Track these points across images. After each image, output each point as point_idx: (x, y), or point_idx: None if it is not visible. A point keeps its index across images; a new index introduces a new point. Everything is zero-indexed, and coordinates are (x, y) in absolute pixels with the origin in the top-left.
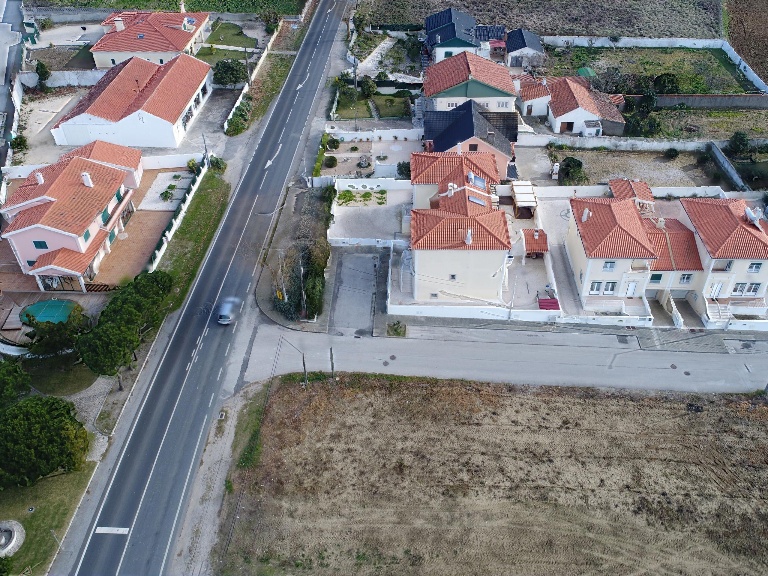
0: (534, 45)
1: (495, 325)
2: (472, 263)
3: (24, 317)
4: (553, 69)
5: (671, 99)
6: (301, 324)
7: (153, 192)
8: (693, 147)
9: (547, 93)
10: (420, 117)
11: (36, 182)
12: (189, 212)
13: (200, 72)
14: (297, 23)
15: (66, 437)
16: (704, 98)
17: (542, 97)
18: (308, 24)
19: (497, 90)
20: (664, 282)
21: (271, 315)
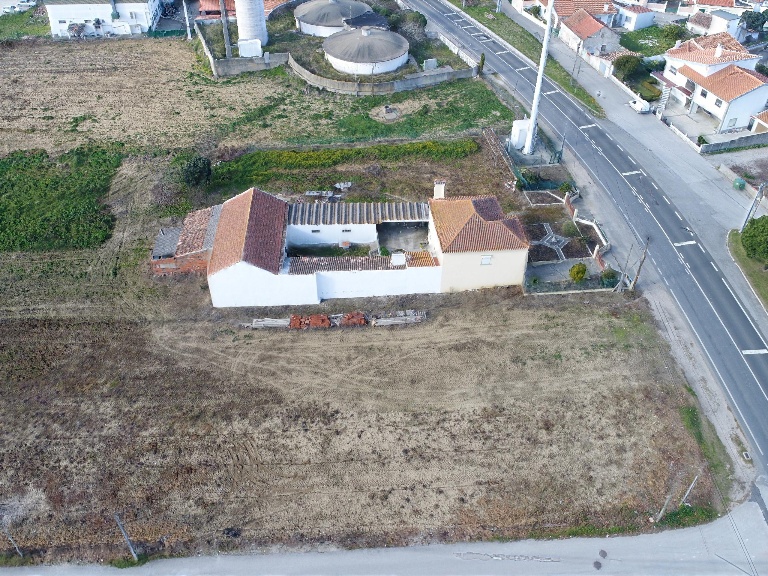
0: None
1: None
2: None
3: None
4: None
5: None
6: None
7: None
8: None
9: None
10: None
11: None
12: None
13: None
14: None
15: None
16: None
17: None
18: None
19: None
20: None
21: None
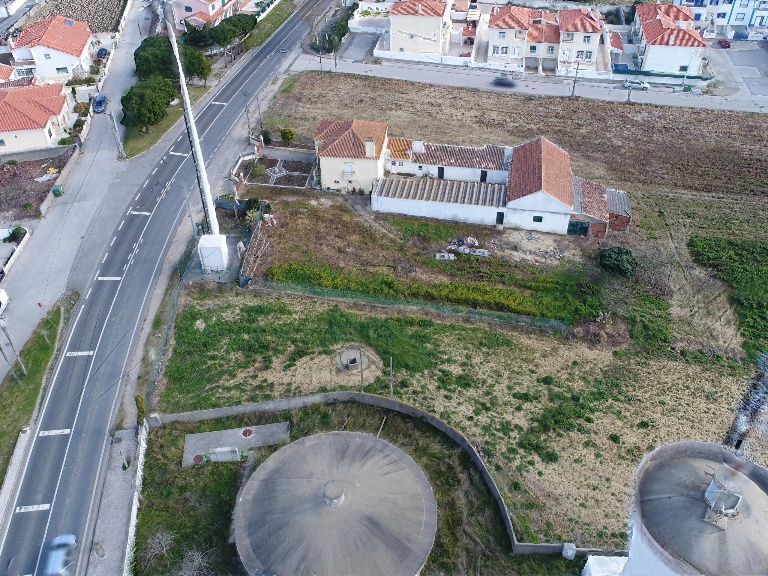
0: None
1: (433, 64)
2: (422, 26)
3: None
4: None
5: None
6: (324, 55)
7: (251, 4)
8: (607, 10)
9: None
10: None
11: None
12: (271, 13)
13: None
14: None
15: (202, 60)
16: None
17: None
18: None
19: None
20: (538, 52)
21: (309, 50)
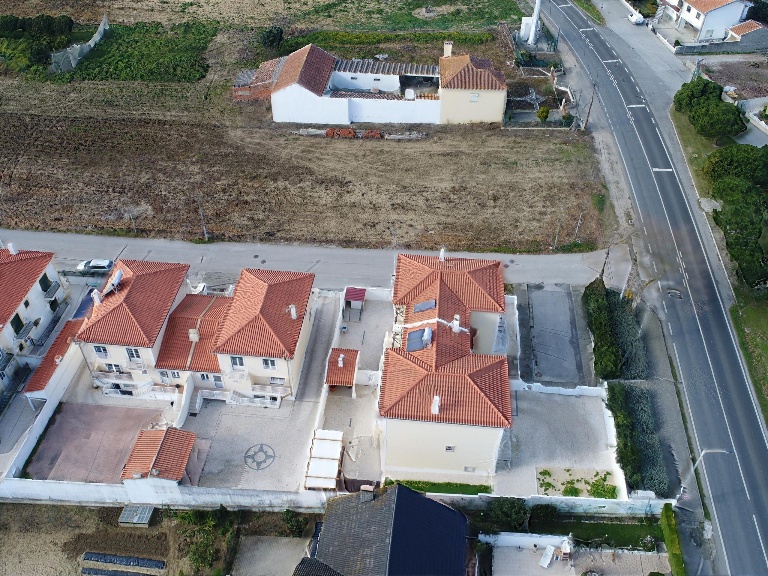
0: None
1: None
2: None
3: None
4: None
5: None
6: None
7: None
8: None
9: None
10: None
11: None
12: None
13: None
14: None
15: None
16: None
17: None
18: None
19: None
20: None
21: None
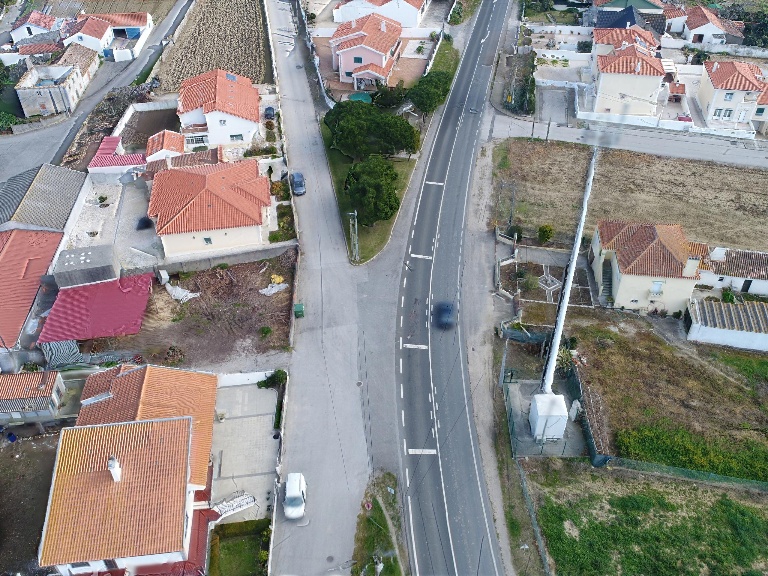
0: None
1: (648, 129)
2: (638, 86)
3: (351, 99)
4: (687, 5)
5: None
6: (522, 117)
7: (409, 49)
8: None
9: (685, 14)
10: (586, 25)
11: (349, 27)
12: (436, 61)
13: None
14: None
15: (413, 131)
16: None
17: (680, 17)
18: None
19: (650, 3)
20: (765, 115)
21: (503, 111)
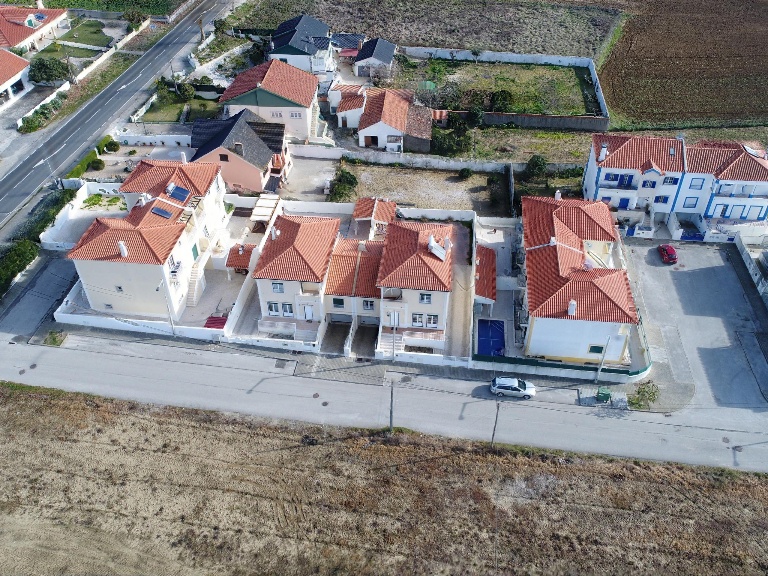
0: (383, 55)
1: (158, 340)
2: (133, 276)
3: None
4: (401, 81)
5: (499, 117)
6: None
7: None
8: (491, 168)
9: (361, 105)
10: None
11: None
12: None
13: (14, 68)
14: (164, 23)
15: None
16: (534, 118)
17: (354, 109)
18: (175, 25)
19: (286, 100)
20: (348, 307)
21: None
